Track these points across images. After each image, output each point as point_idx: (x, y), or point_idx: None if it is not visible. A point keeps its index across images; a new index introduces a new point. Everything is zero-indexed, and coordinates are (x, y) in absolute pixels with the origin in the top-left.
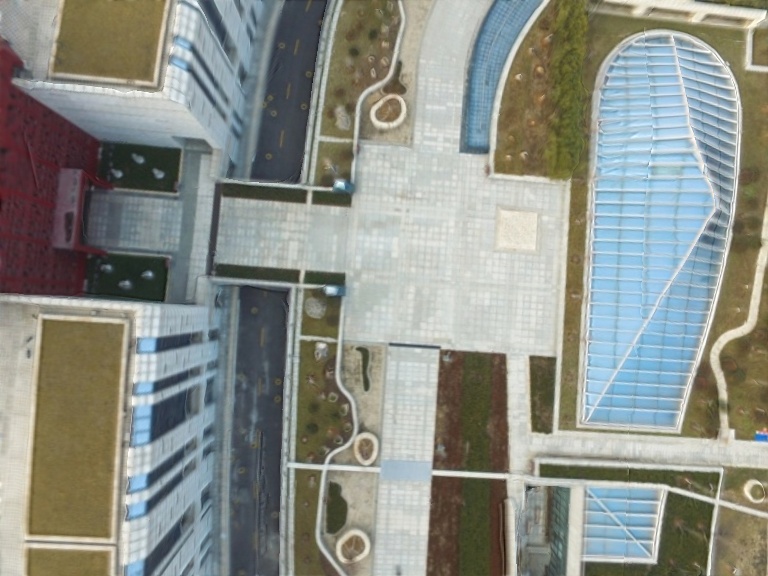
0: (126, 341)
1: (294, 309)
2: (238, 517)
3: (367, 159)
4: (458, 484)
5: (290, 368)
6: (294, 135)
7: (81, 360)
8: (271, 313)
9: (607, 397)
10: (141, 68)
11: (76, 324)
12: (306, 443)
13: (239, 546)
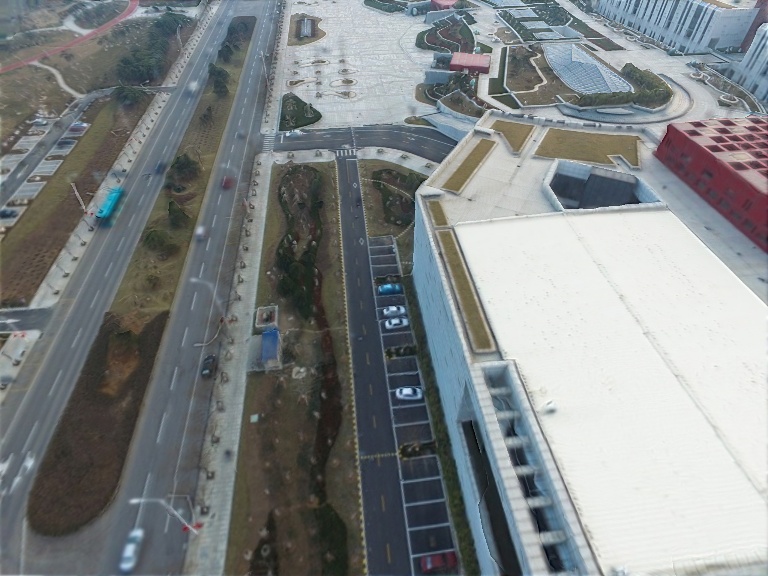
0: None
1: None
2: None
3: None
4: None
5: None
6: None
7: (728, 7)
8: None
9: None
10: None
11: None
12: None
13: None
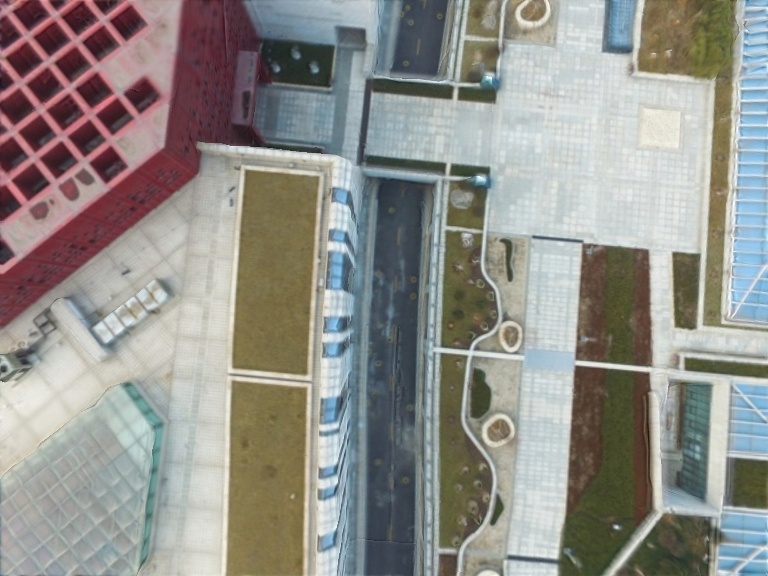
0: (320, 192)
1: (440, 200)
2: (375, 408)
3: (511, 58)
4: (601, 375)
5: (436, 257)
6: (430, 43)
7: (280, 209)
8: (407, 213)
9: (754, 293)
10: None
11: (275, 175)
12: (452, 329)
13: (376, 436)
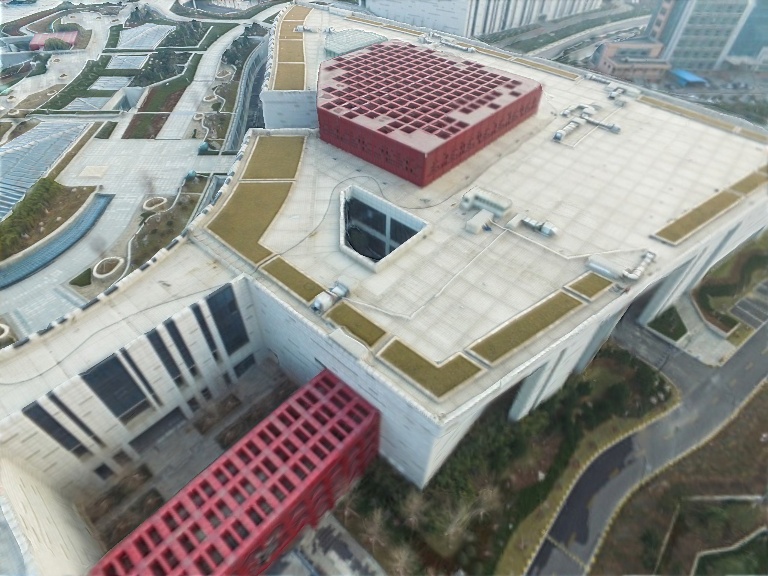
0: None
1: None
2: None
3: None
4: None
5: None
6: None
7: None
8: None
9: None
10: (265, 139)
11: None
12: None
13: None
